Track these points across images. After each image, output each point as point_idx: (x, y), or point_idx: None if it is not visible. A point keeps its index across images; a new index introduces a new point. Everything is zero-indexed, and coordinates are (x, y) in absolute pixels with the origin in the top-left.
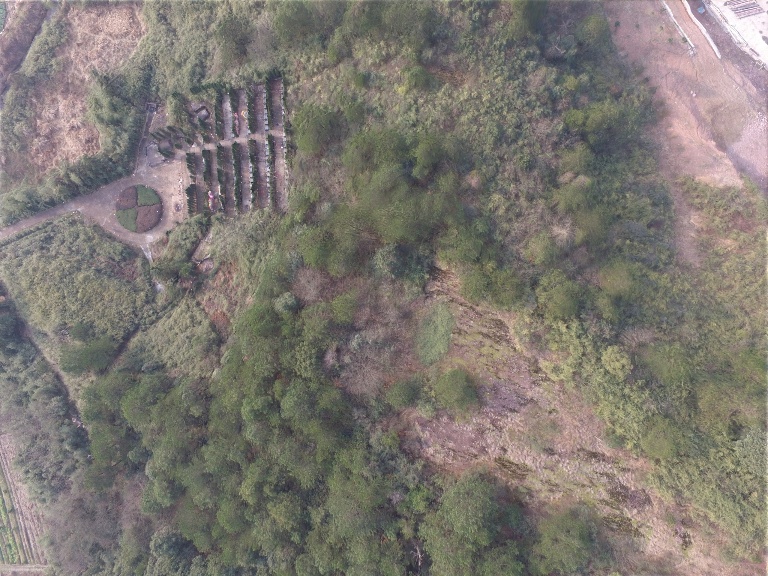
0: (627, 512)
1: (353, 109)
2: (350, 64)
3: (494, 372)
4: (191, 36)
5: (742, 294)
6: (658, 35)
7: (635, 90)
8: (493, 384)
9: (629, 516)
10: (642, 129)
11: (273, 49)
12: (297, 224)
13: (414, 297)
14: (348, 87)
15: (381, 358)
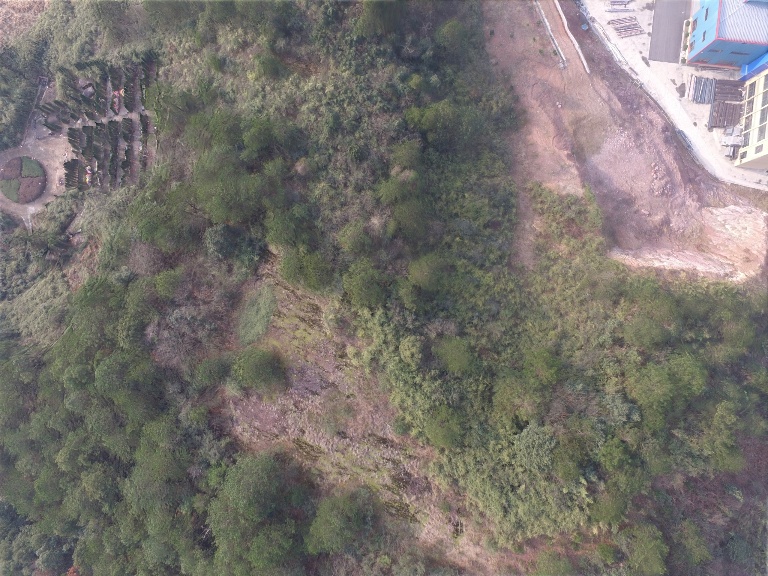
0: (406, 498)
1: (208, 92)
2: (212, 49)
3: (303, 355)
4: (85, 14)
5: (560, 297)
6: (531, 46)
7: (494, 96)
8: (301, 366)
9: (407, 502)
10: (500, 134)
11: (151, 31)
12: (147, 201)
13: (242, 278)
14: (209, 71)
15: (198, 334)
